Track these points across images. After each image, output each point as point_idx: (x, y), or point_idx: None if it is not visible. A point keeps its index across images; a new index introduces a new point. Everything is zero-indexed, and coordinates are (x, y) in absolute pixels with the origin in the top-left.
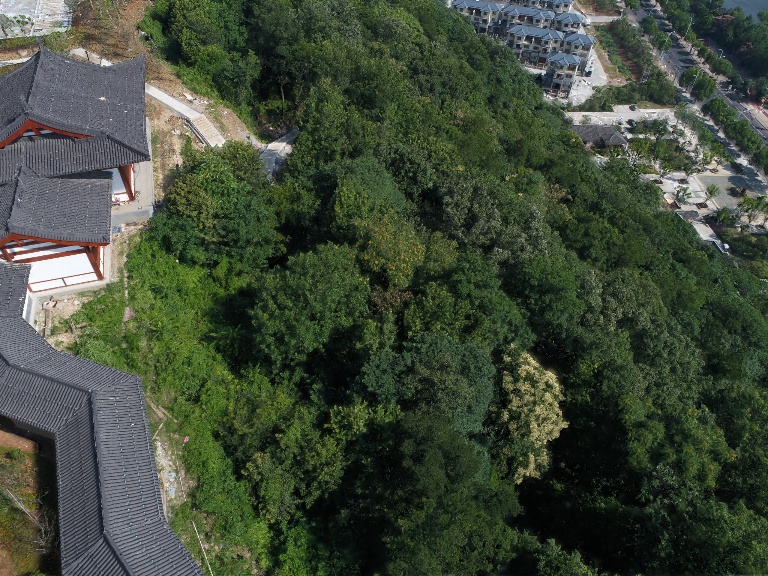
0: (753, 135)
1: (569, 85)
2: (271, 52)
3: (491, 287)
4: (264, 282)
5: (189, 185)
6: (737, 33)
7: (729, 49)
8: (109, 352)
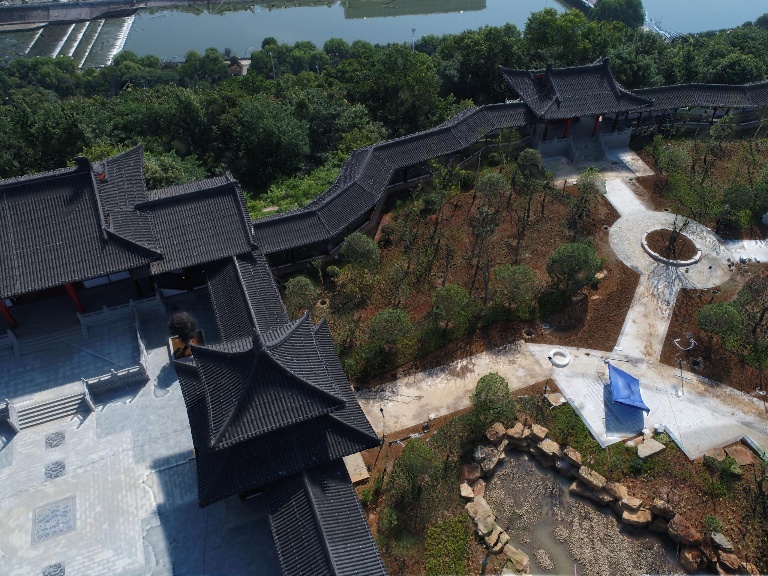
0: None
1: None
2: None
3: None
4: (269, 125)
5: None
6: None
7: None
8: None
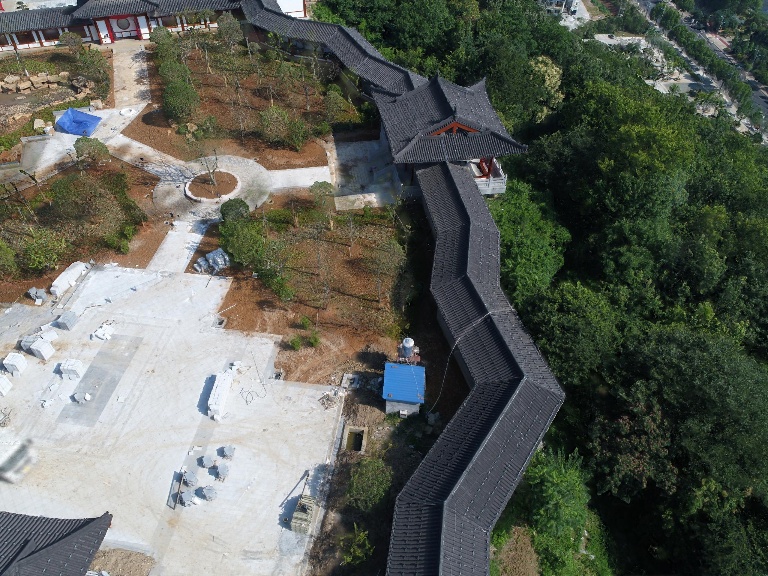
0: (708, 50)
1: None
2: None
3: (521, 20)
4: (402, 6)
5: None
6: None
7: None
8: None
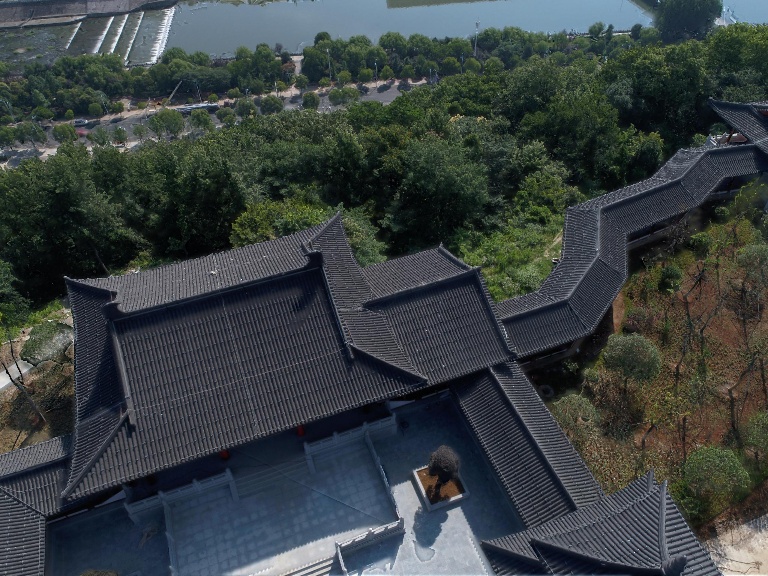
0: None
1: None
2: None
3: None
4: (452, 173)
5: None
6: None
7: None
8: None
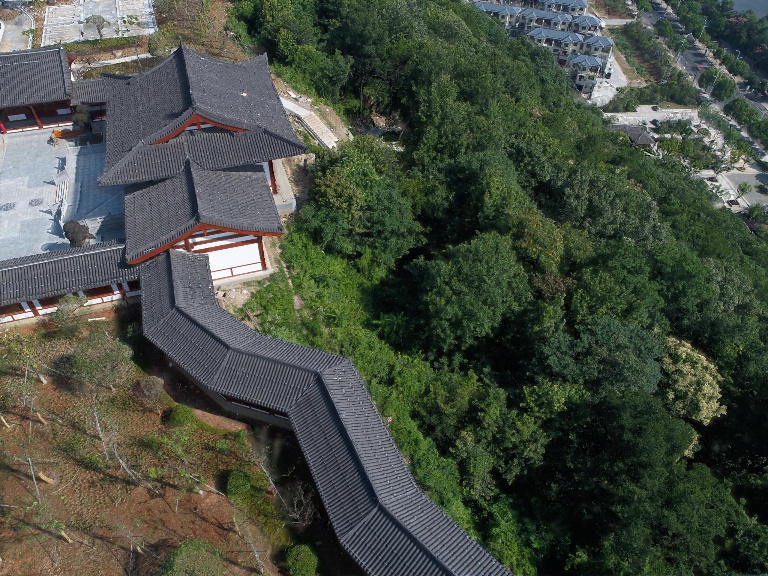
0: None
1: (591, 86)
2: (356, 52)
3: (643, 273)
4: (438, 269)
5: (337, 178)
6: (751, 35)
7: (745, 50)
8: (294, 338)
